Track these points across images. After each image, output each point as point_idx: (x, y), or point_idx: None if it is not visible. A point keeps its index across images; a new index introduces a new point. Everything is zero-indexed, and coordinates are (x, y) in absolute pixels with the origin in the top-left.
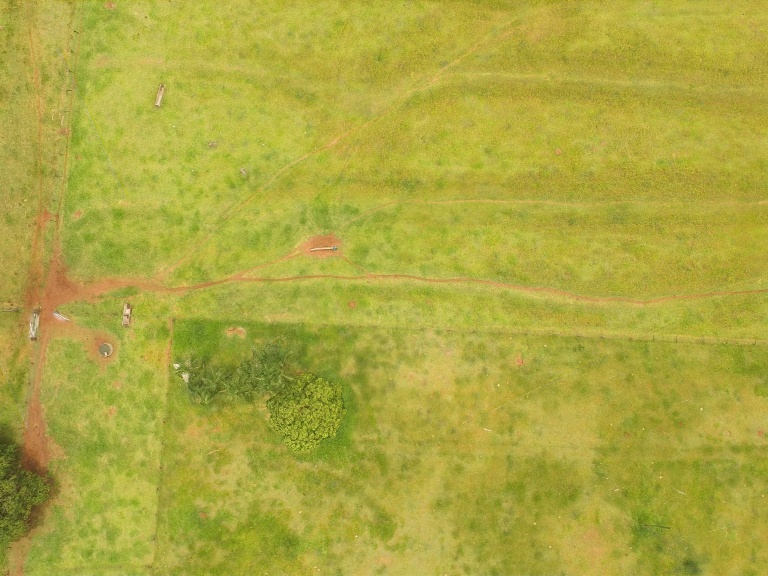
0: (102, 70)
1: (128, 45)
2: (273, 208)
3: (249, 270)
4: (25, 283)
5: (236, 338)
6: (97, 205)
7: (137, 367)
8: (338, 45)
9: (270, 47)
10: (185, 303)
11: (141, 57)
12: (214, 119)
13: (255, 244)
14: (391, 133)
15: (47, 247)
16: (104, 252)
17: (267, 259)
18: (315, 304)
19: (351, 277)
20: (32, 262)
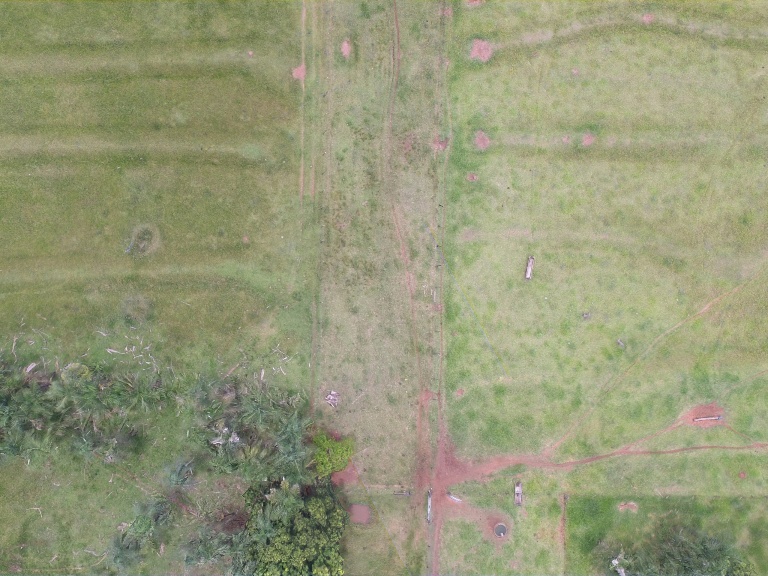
0: (470, 244)
1: (493, 217)
2: (653, 379)
3: (634, 443)
4: (414, 464)
5: (629, 513)
6: (479, 382)
7: (532, 546)
8: (701, 209)
9: (634, 213)
10: (573, 479)
11: (508, 229)
12: (585, 289)
13: (638, 416)
14: (763, 297)
15: (433, 427)
16: (490, 430)
17: (651, 431)
18: (704, 476)
19: (738, 447)
20: (419, 443)
